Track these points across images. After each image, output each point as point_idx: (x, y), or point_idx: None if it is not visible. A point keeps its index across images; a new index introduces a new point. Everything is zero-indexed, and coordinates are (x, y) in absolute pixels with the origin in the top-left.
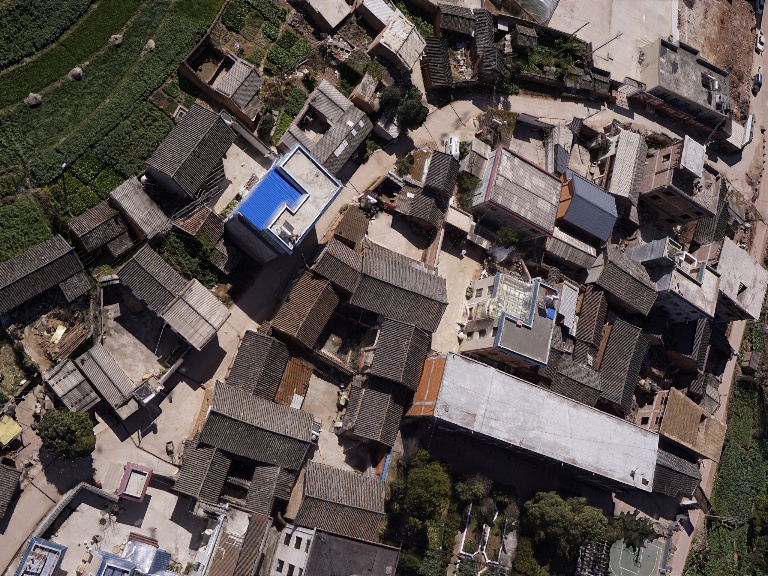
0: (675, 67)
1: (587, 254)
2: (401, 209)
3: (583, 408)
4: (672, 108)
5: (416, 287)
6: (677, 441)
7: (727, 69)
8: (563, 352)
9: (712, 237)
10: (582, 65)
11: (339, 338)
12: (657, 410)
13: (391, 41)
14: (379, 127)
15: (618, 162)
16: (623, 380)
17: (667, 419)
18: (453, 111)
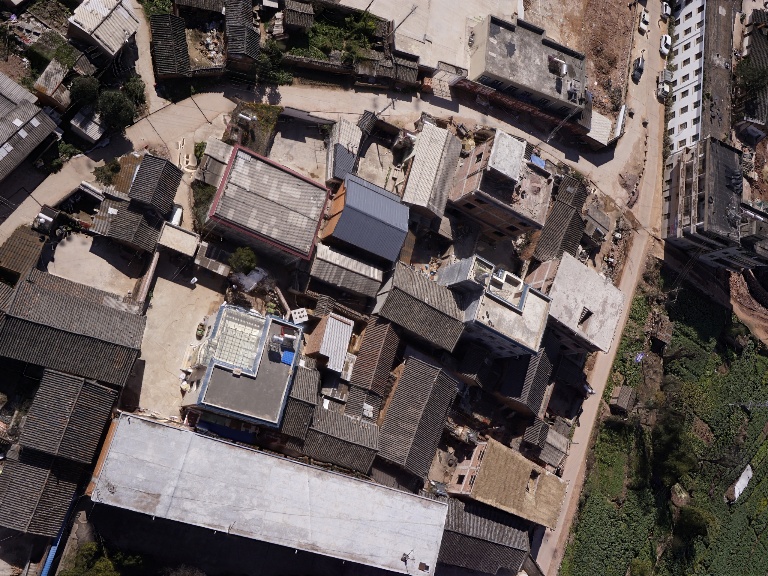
0: (511, 49)
1: (368, 278)
2: (97, 229)
3: (332, 477)
4: (508, 98)
5: (94, 329)
6: (495, 506)
7: (594, 52)
8: (314, 404)
9: (556, 252)
10: (383, 48)
11: (3, 395)
12: (473, 467)
13: (85, 19)
14: (75, 127)
15: (417, 164)
16: (412, 434)
17: (481, 479)
18: (195, 106)
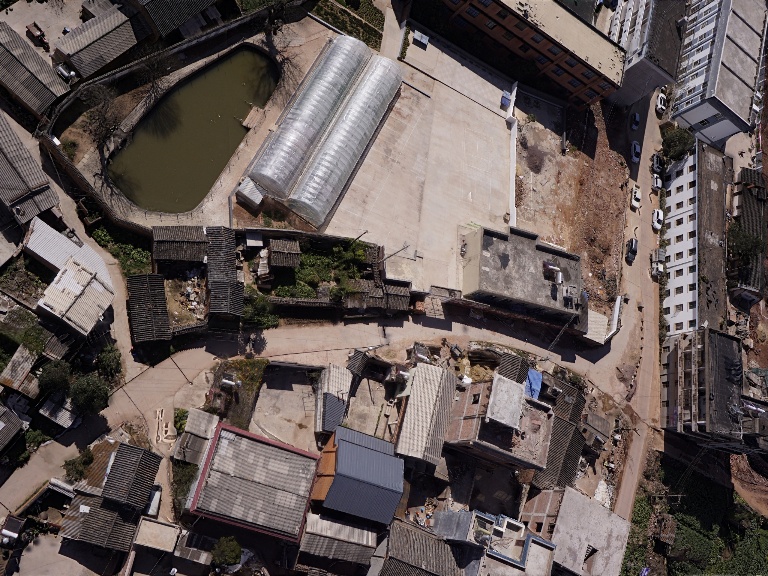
0: (505, 260)
1: (361, 546)
2: (67, 532)
3: None
4: (503, 311)
5: None
6: None
7: (588, 241)
8: None
9: (556, 477)
10: (372, 275)
11: None
12: None
13: (56, 300)
14: None
15: (411, 409)
16: None
17: None
18: (174, 366)
